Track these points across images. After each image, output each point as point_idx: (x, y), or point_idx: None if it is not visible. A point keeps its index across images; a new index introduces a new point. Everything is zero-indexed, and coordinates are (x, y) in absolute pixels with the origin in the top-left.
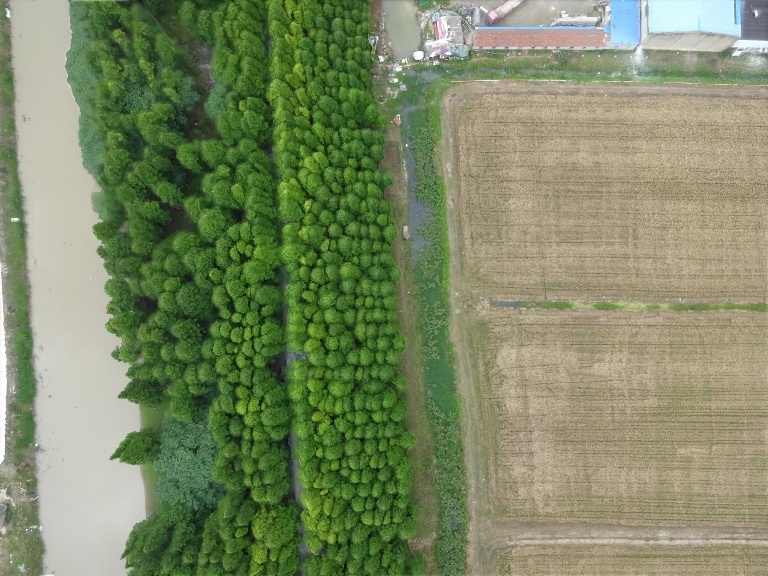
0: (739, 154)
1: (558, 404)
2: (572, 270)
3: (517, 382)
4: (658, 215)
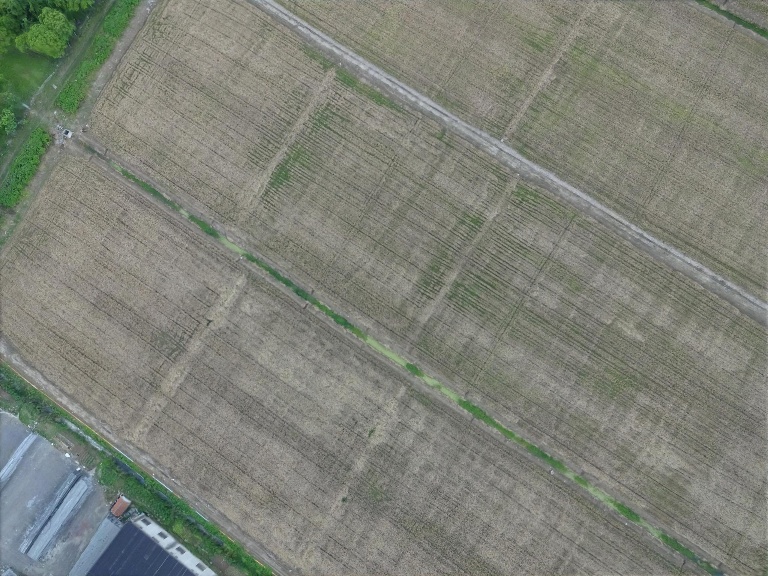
0: (406, 571)
1: (736, 455)
2: (643, 572)
3: (765, 502)
4: (524, 567)
